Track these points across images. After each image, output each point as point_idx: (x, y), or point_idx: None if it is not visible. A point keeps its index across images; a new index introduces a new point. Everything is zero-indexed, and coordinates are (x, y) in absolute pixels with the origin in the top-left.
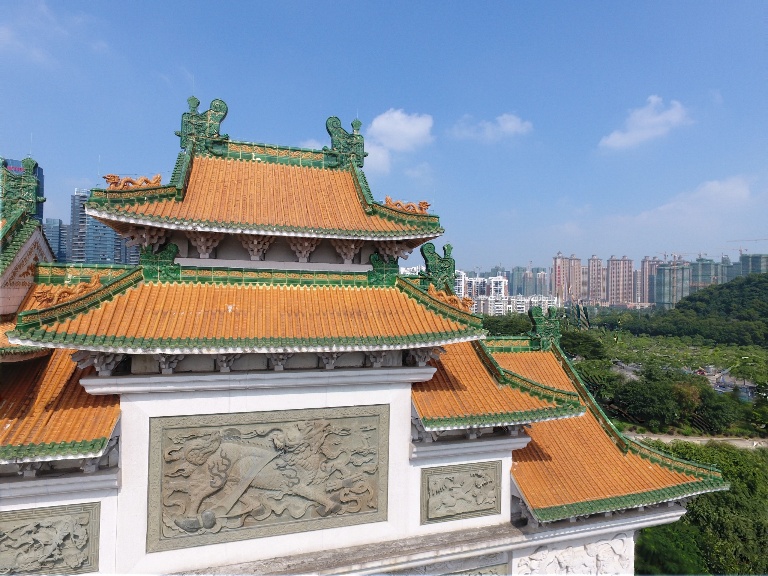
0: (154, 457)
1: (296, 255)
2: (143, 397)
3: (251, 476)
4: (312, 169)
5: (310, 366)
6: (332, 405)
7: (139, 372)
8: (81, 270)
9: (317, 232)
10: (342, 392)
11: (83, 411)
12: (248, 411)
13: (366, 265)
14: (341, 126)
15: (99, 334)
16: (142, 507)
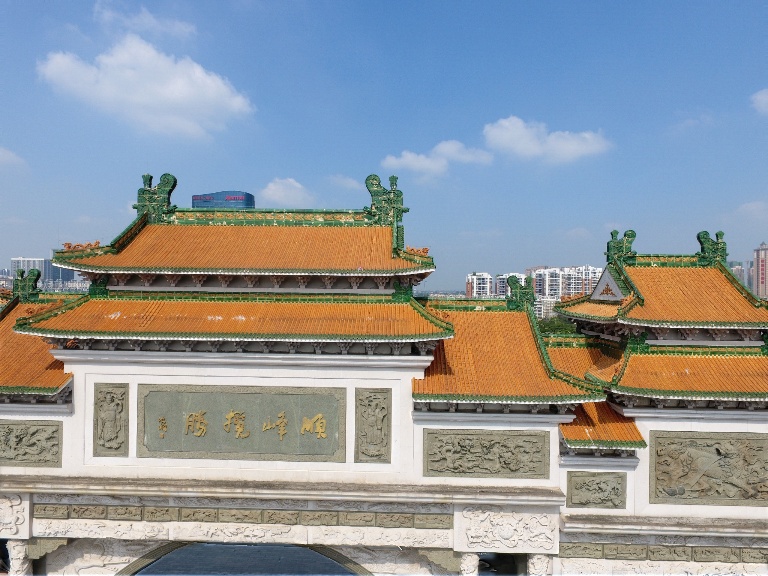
0: (652, 452)
1: (705, 333)
2: (646, 419)
3: (705, 469)
4: (691, 269)
5: (732, 406)
6: (751, 431)
7: (638, 405)
8: (556, 338)
9: (739, 326)
10: (757, 424)
11: (618, 425)
12: (701, 431)
13: (760, 341)
14: (709, 237)
15: (640, 387)
16: (647, 478)
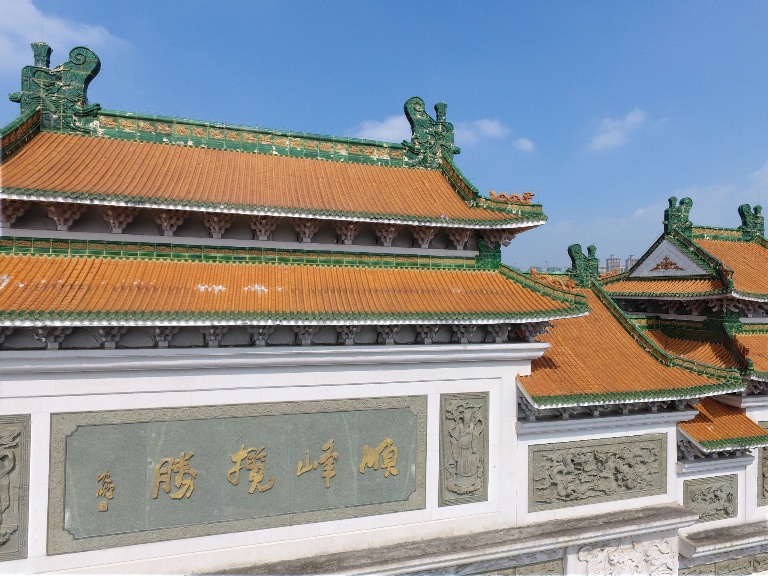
0: None
1: None
2: (755, 409)
3: None
4: (738, 243)
5: None
6: None
7: None
8: None
9: None
10: None
11: None
12: None
13: None
14: None
15: None
16: (755, 478)
